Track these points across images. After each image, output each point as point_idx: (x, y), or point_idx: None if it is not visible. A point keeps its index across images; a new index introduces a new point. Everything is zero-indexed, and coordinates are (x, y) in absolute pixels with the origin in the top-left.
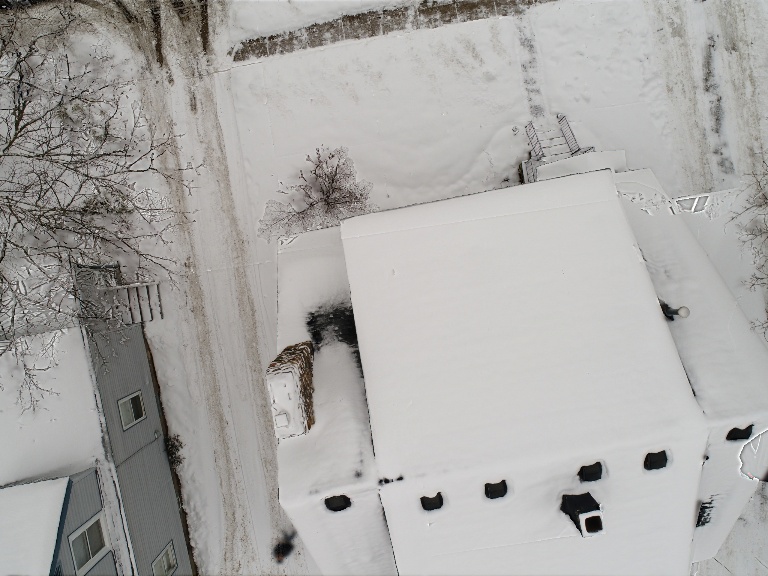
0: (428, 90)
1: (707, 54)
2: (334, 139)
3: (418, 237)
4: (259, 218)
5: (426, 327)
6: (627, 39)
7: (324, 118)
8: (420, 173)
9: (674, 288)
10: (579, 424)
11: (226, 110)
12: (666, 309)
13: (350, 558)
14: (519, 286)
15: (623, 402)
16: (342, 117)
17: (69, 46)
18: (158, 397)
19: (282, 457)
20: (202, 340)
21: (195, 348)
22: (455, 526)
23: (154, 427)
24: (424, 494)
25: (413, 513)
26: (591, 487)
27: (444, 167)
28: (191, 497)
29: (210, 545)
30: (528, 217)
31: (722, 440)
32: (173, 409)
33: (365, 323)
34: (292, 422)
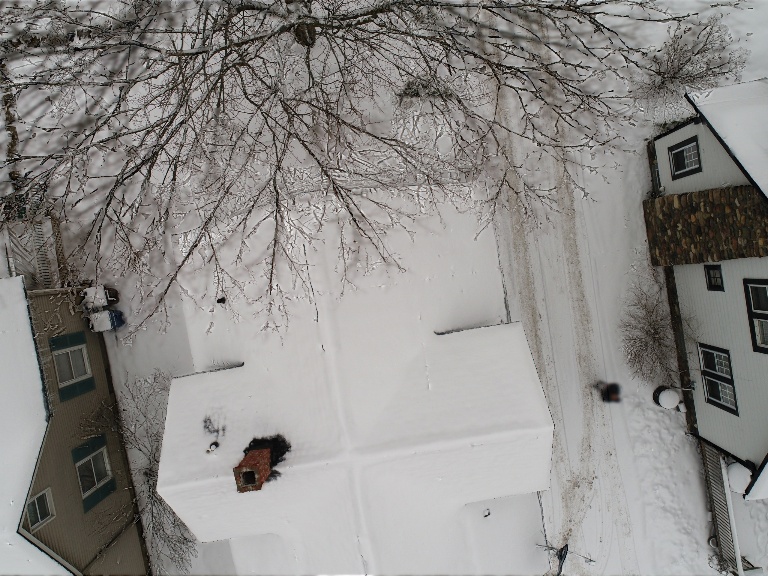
0: None
1: None
2: None
3: None
4: None
5: None
6: None
7: None
8: (760, 55)
9: None
10: None
11: None
12: None
13: None
14: None
15: None
16: None
17: None
18: None
19: None
20: (516, 231)
21: (510, 239)
22: None
23: None
24: None
25: None
26: None
27: None
28: None
29: None
30: None
31: None
32: None
33: None
34: None
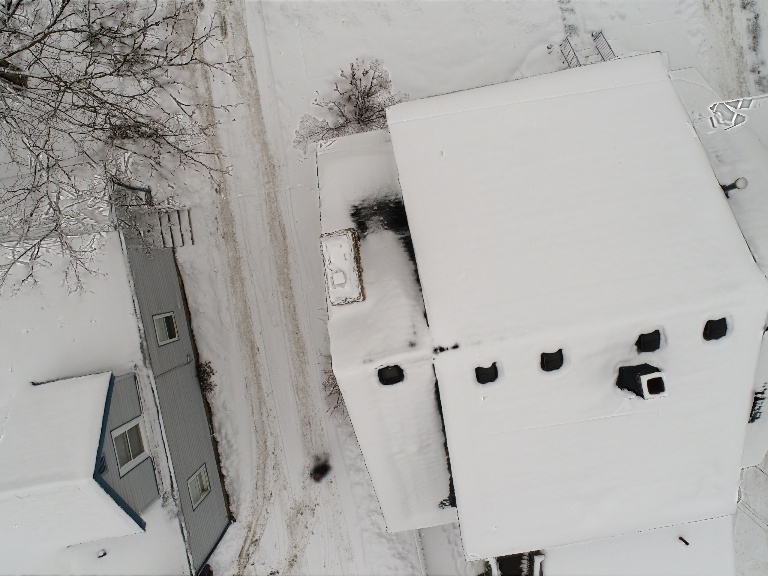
0: (461, 10)
1: None
2: (366, 60)
3: (466, 120)
4: (290, 141)
5: (477, 204)
6: None
7: (356, 39)
8: None
9: (727, 170)
10: (637, 291)
11: (257, 33)
12: (721, 186)
13: (397, 447)
14: (571, 163)
15: (682, 269)
16: (374, 38)
17: None
18: (189, 324)
19: (333, 331)
20: (233, 266)
21: (226, 274)
22: (509, 401)
23: (186, 351)
24: (479, 364)
25: (467, 385)
26: (649, 358)
27: None
28: (222, 425)
29: (242, 473)
30: (578, 98)
31: None
32: (204, 336)
33: (414, 202)
34: (348, 282)
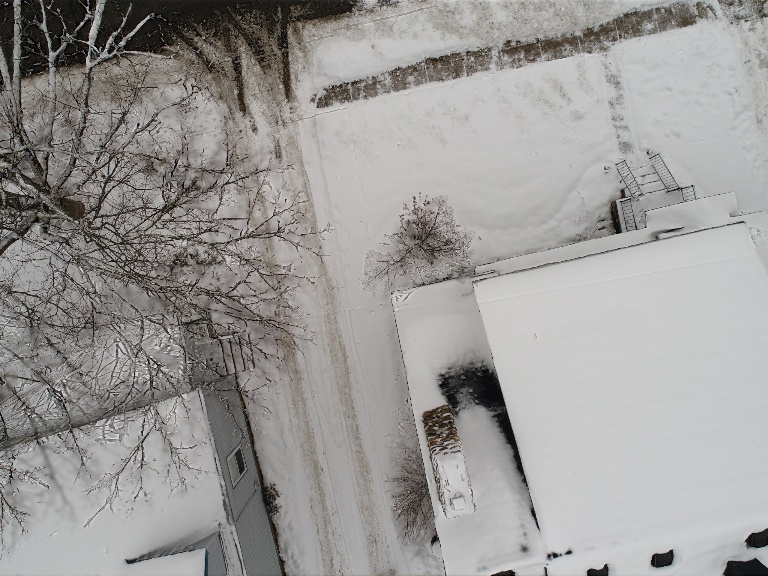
0: (516, 131)
1: None
2: (423, 183)
3: (556, 299)
4: (349, 264)
5: (576, 393)
6: (716, 73)
7: (412, 162)
8: (511, 214)
9: None
10: (747, 491)
11: (312, 157)
12: None
13: None
14: (667, 348)
15: None
16: (430, 161)
17: (153, 99)
18: (252, 446)
19: (442, 532)
20: (294, 388)
21: (288, 396)
22: None
23: (253, 478)
24: (592, 567)
25: None
26: (758, 553)
27: (535, 207)
28: (288, 545)
29: None
30: (667, 275)
31: None
32: (268, 458)
33: (513, 390)
34: (467, 503)
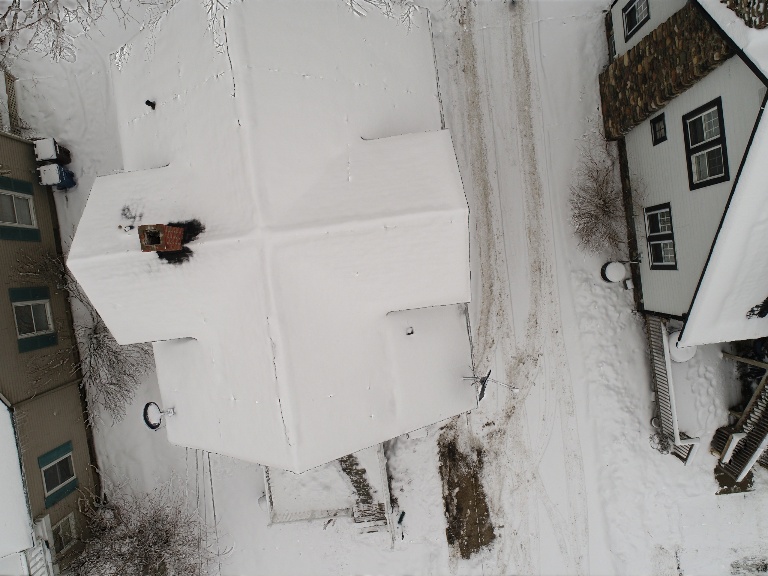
0: None
1: None
2: None
3: None
4: None
5: None
6: None
7: None
8: None
9: None
10: None
11: None
12: None
13: (767, 213)
14: None
15: None
16: None
17: None
18: None
19: (756, 54)
20: (471, 102)
21: (464, 109)
22: None
23: None
24: None
25: None
26: None
27: None
28: None
29: None
30: None
31: None
32: None
33: None
34: None
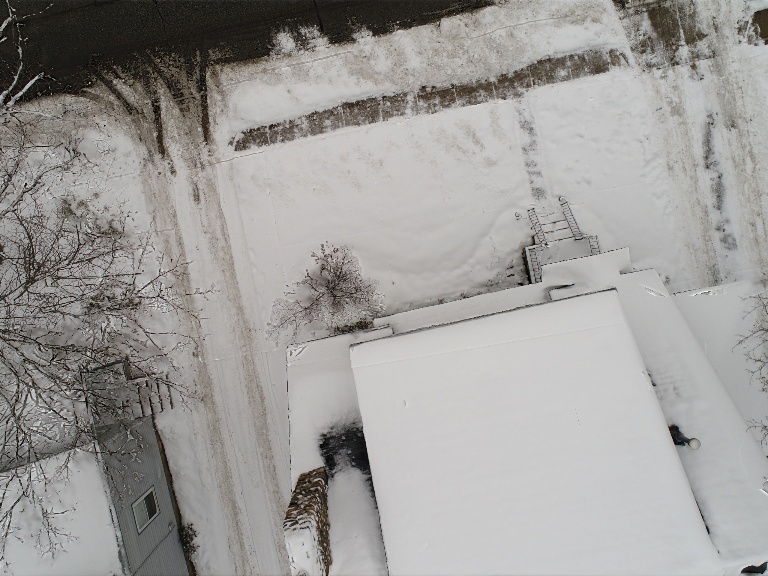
0: (430, 176)
1: (706, 132)
2: (338, 227)
3: (428, 365)
4: (265, 307)
5: (439, 462)
6: (626, 121)
7: (327, 207)
8: (424, 259)
9: (684, 408)
10: (595, 565)
11: (229, 200)
12: (677, 434)
13: None
14: (530, 417)
15: (638, 542)
16: (345, 205)
17: None
18: (170, 486)
19: None
20: (212, 428)
21: (206, 436)
22: None
23: (168, 519)
24: None
25: None
26: None
27: (448, 252)
28: None
29: None
30: (537, 343)
31: (737, 575)
32: (186, 497)
33: (378, 458)
34: None
